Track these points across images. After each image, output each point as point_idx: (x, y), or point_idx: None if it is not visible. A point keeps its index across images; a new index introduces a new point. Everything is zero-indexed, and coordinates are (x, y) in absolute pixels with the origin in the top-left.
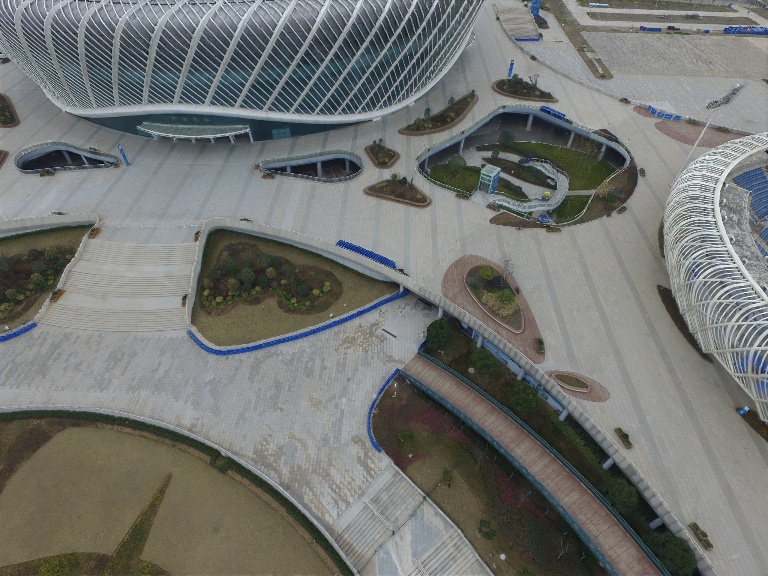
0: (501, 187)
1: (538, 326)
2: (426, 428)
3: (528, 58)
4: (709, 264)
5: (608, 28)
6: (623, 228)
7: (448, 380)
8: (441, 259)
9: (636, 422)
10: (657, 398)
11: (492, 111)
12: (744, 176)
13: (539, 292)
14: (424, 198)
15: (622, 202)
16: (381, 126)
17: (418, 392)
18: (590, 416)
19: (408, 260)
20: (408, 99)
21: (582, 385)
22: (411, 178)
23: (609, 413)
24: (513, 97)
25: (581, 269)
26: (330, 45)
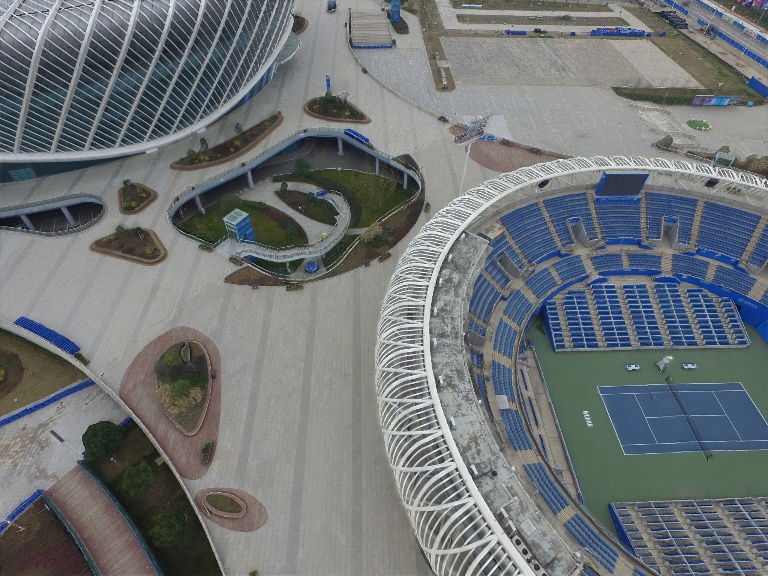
0: (279, 228)
1: (219, 423)
2: (46, 574)
3: (359, 71)
4: (393, 348)
5: (472, 32)
6: (377, 281)
7: (98, 502)
8: (142, 335)
9: (282, 559)
10: (323, 520)
11: (288, 137)
12: (515, 214)
13: (241, 374)
14: (155, 253)
15: (390, 247)
16: (153, 159)
17: (56, 521)
18: (228, 554)
19: (100, 339)
20: (193, 125)
21: (235, 508)
22: (157, 226)
23: (254, 548)
24: (322, 118)
25: (306, 339)
26: (22, 76)
